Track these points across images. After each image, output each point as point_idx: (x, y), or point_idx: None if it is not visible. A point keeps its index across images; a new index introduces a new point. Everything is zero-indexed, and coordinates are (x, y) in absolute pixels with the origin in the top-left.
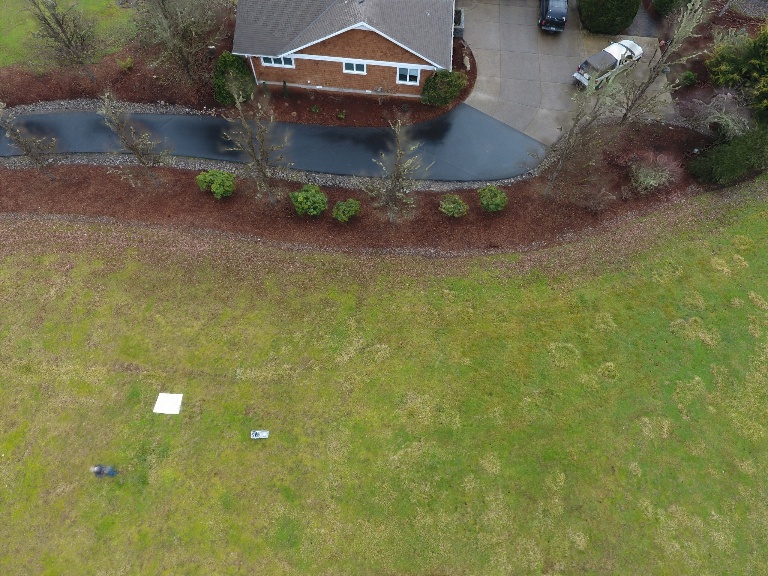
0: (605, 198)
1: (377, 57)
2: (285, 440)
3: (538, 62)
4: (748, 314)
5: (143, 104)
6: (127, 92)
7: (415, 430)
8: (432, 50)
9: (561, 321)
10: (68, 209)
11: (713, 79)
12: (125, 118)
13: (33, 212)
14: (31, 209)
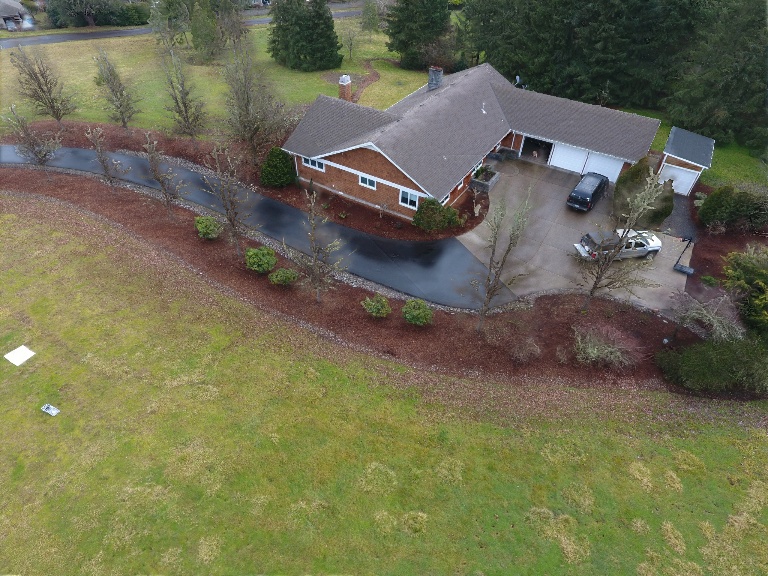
0: (534, 351)
1: (384, 177)
2: (63, 425)
3: (549, 228)
4: (648, 547)
5: (214, 171)
6: (210, 162)
7: (171, 475)
8: (430, 182)
9: (402, 446)
10: (103, 212)
11: (721, 282)
12: (195, 176)
13: (82, 207)
14: (83, 205)
